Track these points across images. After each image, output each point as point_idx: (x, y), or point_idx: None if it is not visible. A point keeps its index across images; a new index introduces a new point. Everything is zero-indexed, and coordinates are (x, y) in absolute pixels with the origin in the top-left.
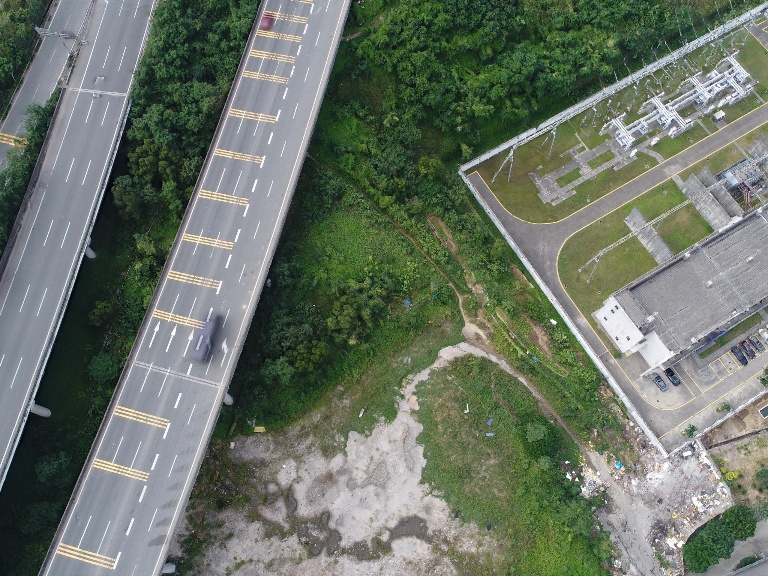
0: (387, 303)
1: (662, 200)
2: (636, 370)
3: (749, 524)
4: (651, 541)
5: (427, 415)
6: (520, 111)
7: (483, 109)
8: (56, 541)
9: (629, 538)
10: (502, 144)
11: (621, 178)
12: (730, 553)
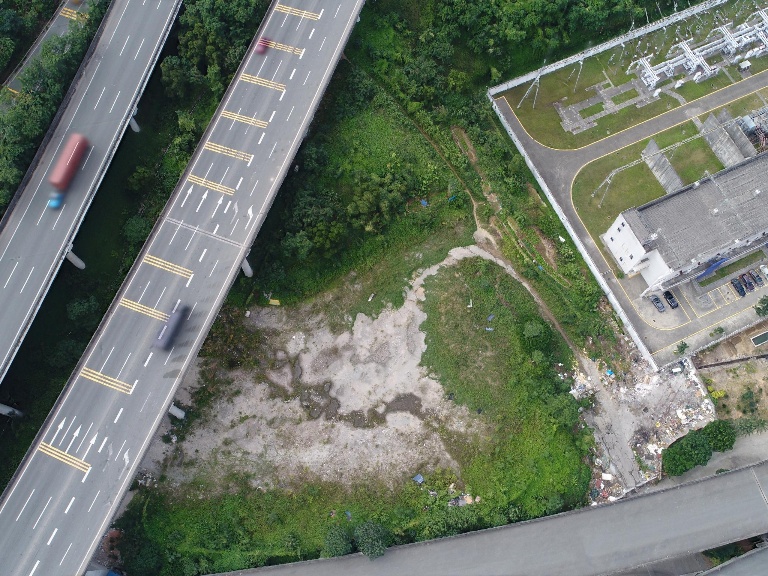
0: (405, 200)
1: (680, 139)
2: (636, 291)
3: (728, 436)
4: (633, 445)
5: (432, 306)
6: (551, 41)
7: (515, 33)
8: (81, 365)
9: (612, 440)
10: (531, 72)
11: (642, 115)
12: (707, 460)
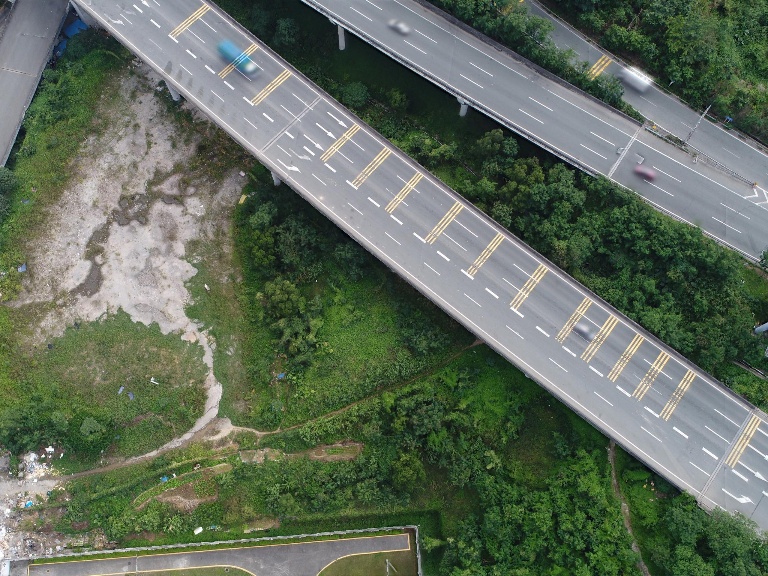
0: None
1: None
2: None
3: None
4: None
5: (172, 343)
6: None
7: None
8: (214, 5)
9: None
10: None
11: None
12: None
